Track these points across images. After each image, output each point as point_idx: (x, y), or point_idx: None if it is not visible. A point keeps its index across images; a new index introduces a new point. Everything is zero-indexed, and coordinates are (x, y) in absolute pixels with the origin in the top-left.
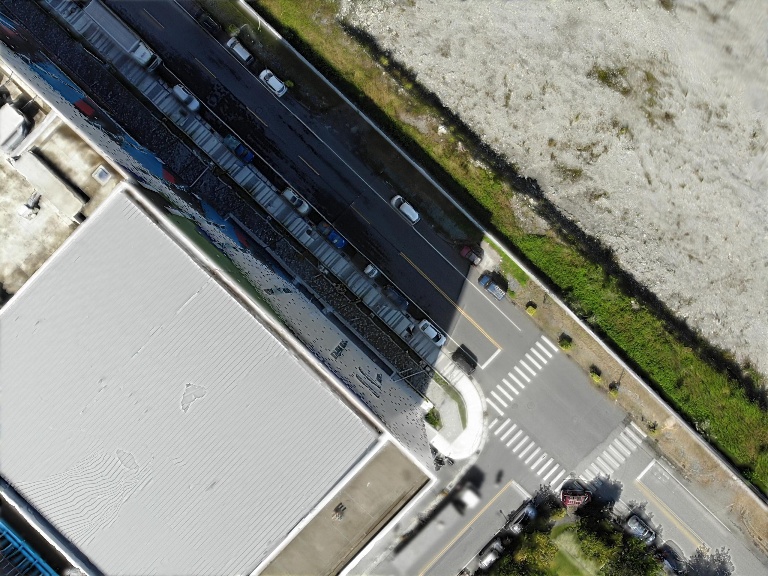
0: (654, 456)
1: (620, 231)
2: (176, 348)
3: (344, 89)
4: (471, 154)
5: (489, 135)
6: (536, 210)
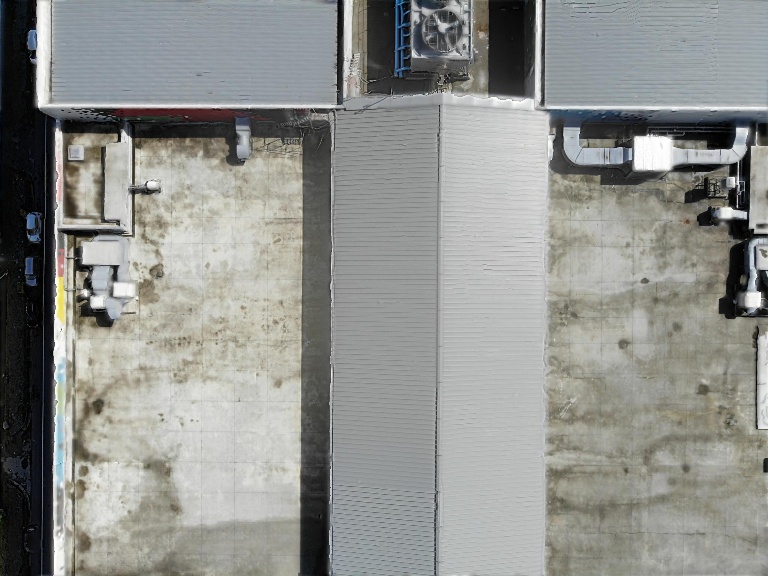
0: None
1: None
2: None
3: None
4: None
5: None
6: None
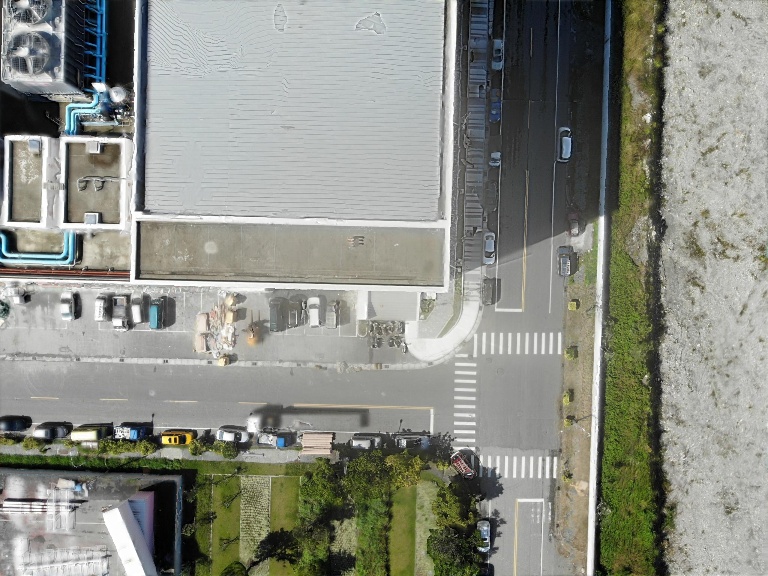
0: (545, 496)
1: (686, 324)
2: (368, 6)
3: (613, 16)
4: (649, 156)
5: (670, 161)
6: (650, 243)
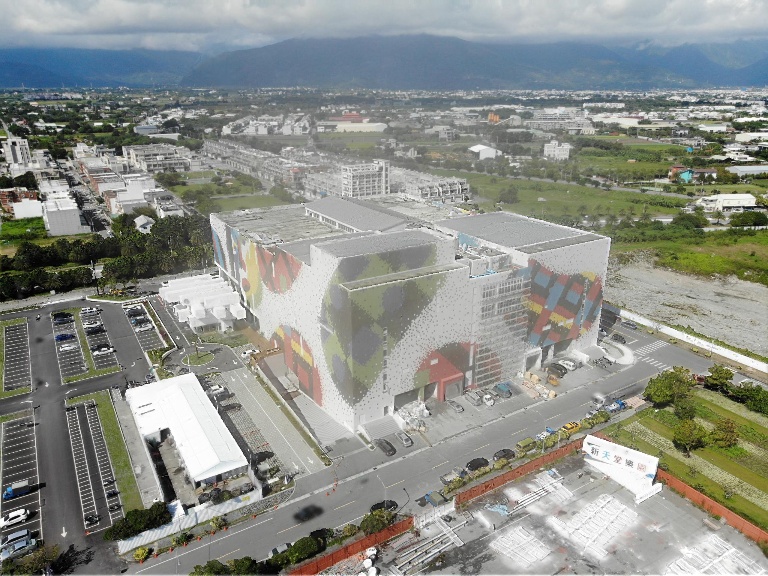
0: None
1: None
2: None
3: None
4: None
5: None
6: None
